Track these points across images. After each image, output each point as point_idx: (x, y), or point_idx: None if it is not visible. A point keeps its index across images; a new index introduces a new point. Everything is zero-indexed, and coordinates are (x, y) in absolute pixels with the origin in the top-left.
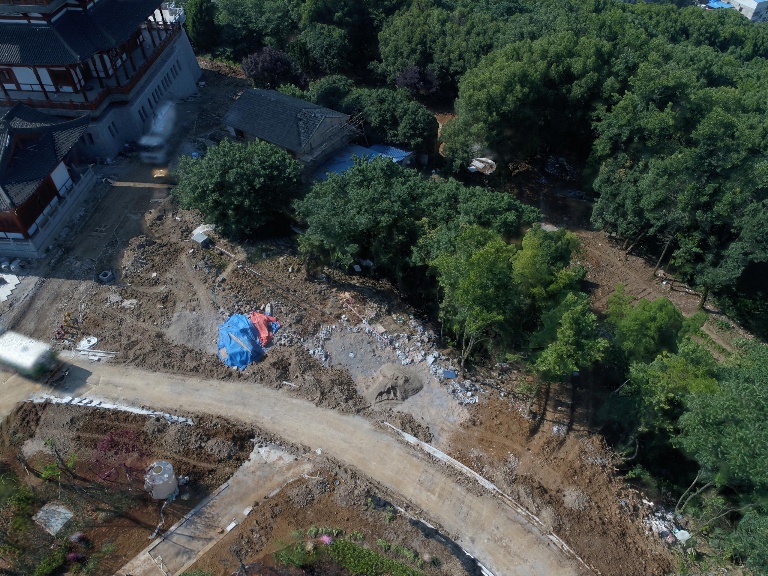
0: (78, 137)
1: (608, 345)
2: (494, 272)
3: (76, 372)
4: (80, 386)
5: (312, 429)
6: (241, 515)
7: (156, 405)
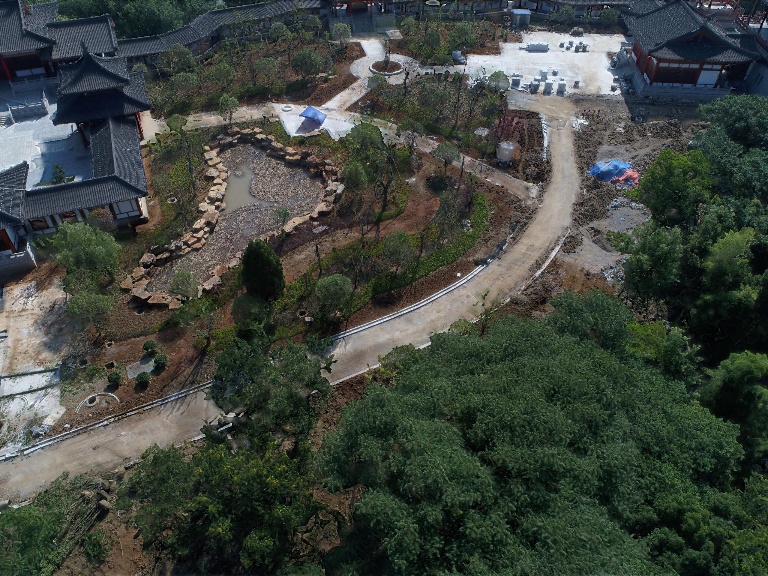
0: (737, 60)
1: (642, 258)
2: (670, 180)
3: (563, 123)
4: (554, 125)
5: (555, 203)
6: (495, 183)
7: (552, 149)
